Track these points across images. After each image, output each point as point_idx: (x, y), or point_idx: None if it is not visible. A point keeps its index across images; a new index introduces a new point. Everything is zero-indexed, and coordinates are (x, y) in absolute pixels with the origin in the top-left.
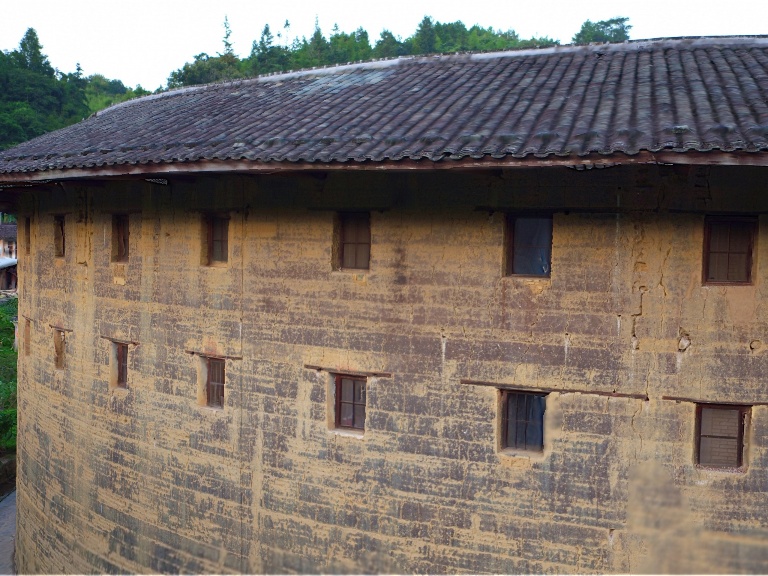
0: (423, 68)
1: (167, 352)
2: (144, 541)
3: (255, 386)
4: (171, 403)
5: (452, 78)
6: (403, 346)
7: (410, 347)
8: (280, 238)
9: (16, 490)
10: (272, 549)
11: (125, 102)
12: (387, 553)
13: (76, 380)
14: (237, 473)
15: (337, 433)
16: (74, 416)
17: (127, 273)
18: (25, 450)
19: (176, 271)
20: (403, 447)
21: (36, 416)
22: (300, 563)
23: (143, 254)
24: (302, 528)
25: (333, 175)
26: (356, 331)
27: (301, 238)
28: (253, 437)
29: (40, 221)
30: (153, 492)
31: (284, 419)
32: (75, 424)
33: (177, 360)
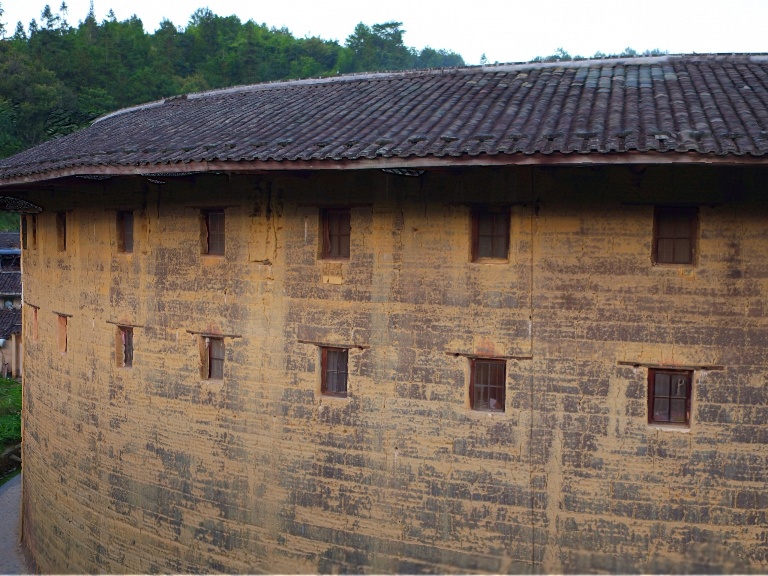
0: (702, 66)
1: (416, 355)
2: (381, 559)
3: (551, 386)
4: (423, 409)
5: (763, 78)
6: (738, 339)
7: (745, 339)
8: (585, 233)
9: (67, 521)
10: (576, 552)
11: (256, 85)
12: (720, 543)
13: (250, 391)
14: (526, 477)
15: (659, 428)
16: (246, 431)
17: (348, 271)
18: (121, 474)
19: (431, 268)
20: (738, 438)
21: (154, 434)
22: (613, 563)
23: (375, 251)
24: (616, 527)
25: (654, 170)
26: (682, 325)
27: (613, 233)
28: (549, 438)
29: (164, 215)
30: (395, 505)
31: (592, 418)
32: (248, 439)
33: (433, 363)
